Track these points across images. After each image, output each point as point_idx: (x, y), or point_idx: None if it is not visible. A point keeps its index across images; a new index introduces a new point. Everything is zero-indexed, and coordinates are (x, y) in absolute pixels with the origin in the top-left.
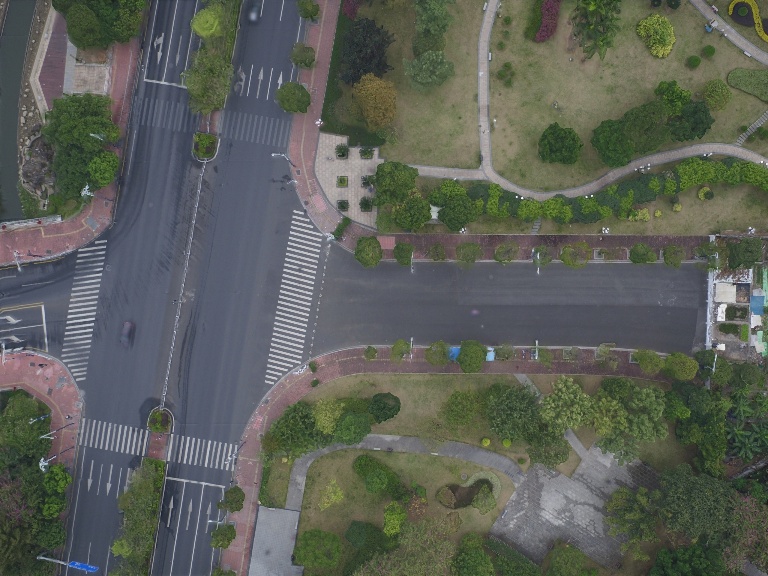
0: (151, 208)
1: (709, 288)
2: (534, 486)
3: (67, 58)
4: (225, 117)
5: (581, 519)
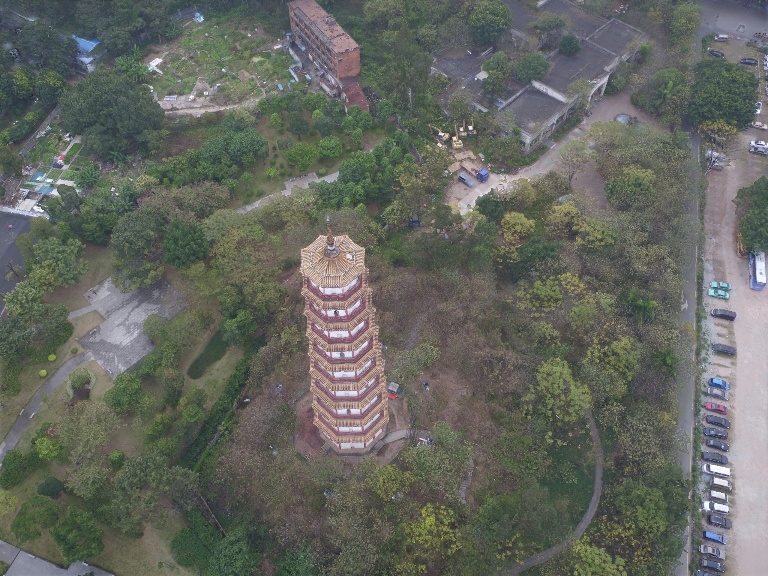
0: None
1: (18, 213)
2: (100, 346)
3: None
4: None
5: (140, 318)
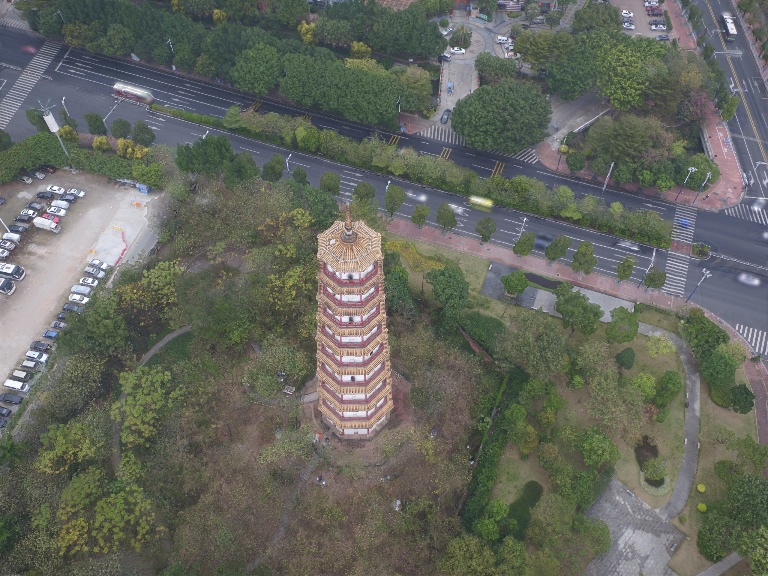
0: None
1: None
2: (657, 528)
3: None
4: None
5: (625, 568)
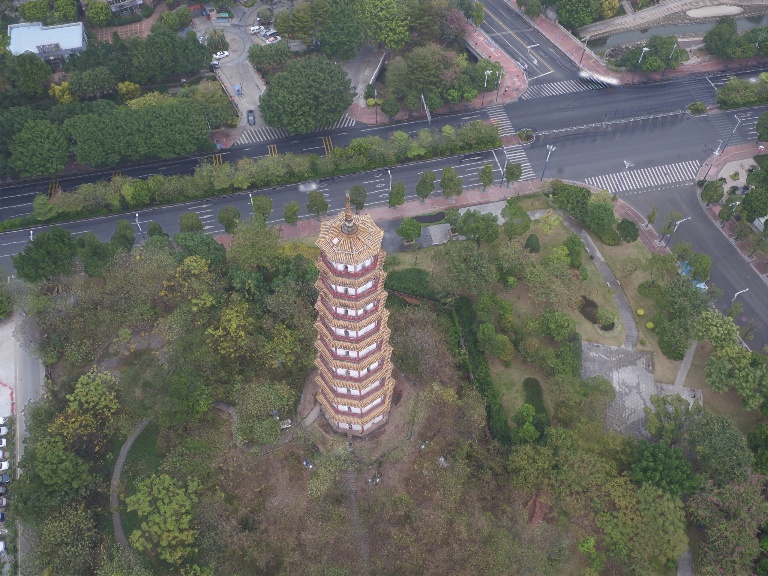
0: (643, 98)
1: None
2: (630, 359)
3: (686, 49)
4: (720, 114)
5: (630, 402)
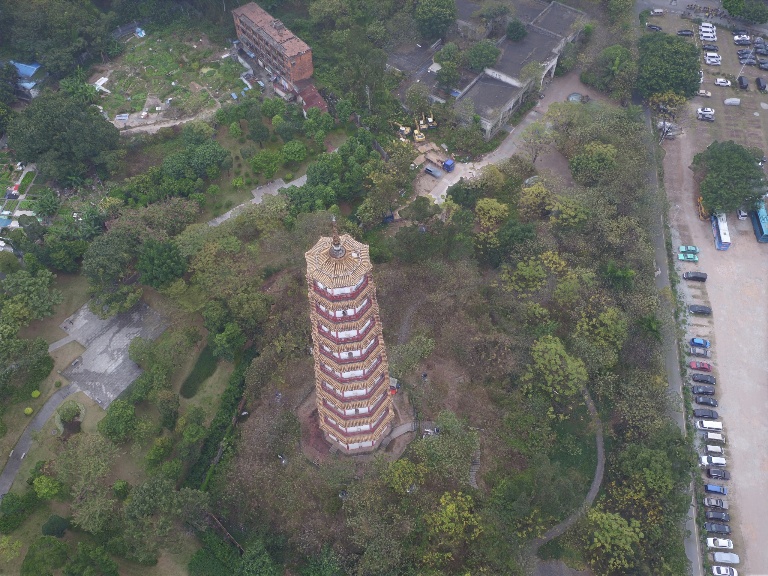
0: None
1: None
2: (84, 377)
3: None
4: None
5: (123, 343)
